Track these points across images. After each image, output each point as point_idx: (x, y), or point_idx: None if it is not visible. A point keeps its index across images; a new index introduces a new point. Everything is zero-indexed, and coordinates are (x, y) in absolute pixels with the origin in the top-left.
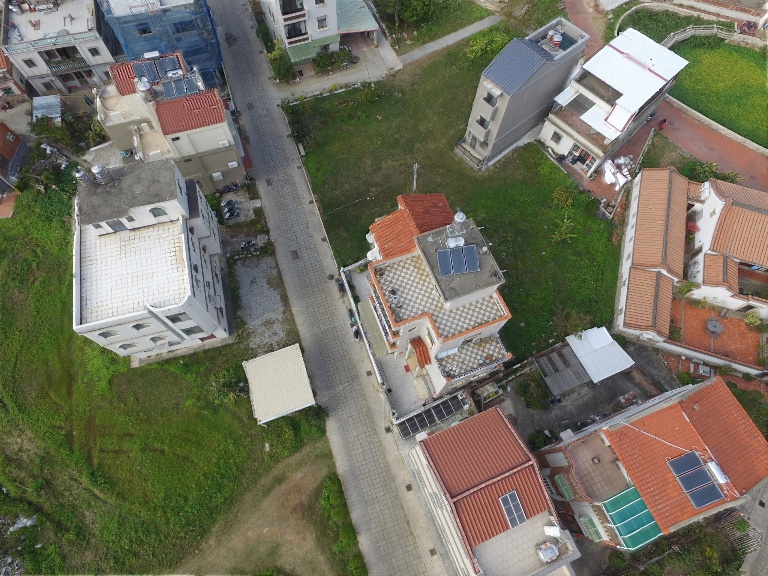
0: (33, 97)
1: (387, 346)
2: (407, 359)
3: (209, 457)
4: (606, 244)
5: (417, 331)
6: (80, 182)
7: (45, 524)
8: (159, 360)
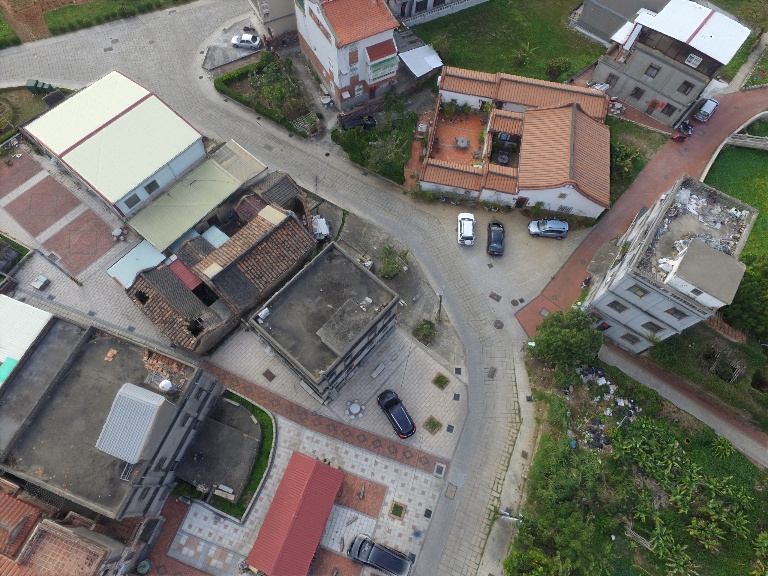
0: None
1: None
2: None
3: None
4: None
5: None
6: None
7: None
8: None
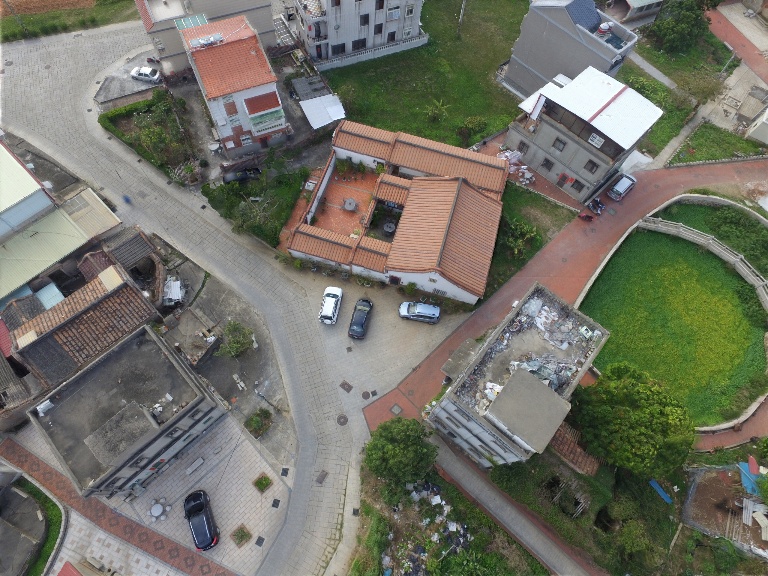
0: None
1: None
2: None
3: None
4: None
5: None
6: None
7: None
8: None
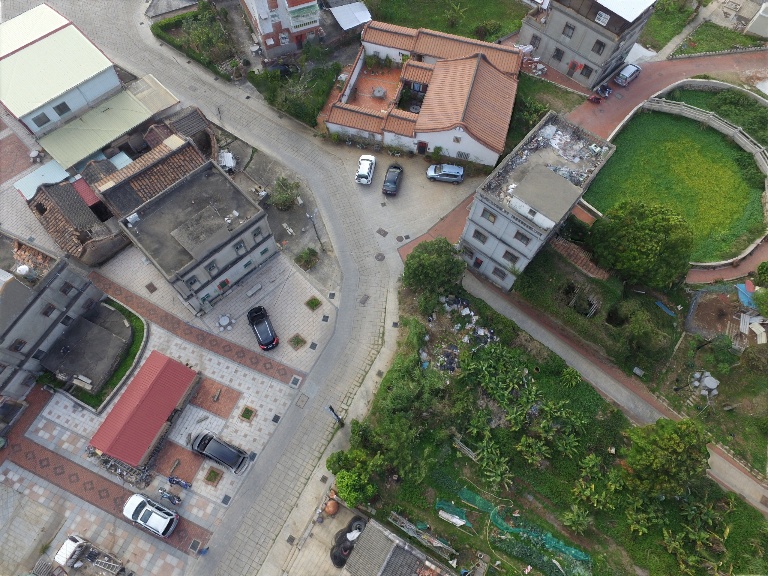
0: None
1: None
2: None
3: None
4: None
5: None
6: None
7: None
8: None
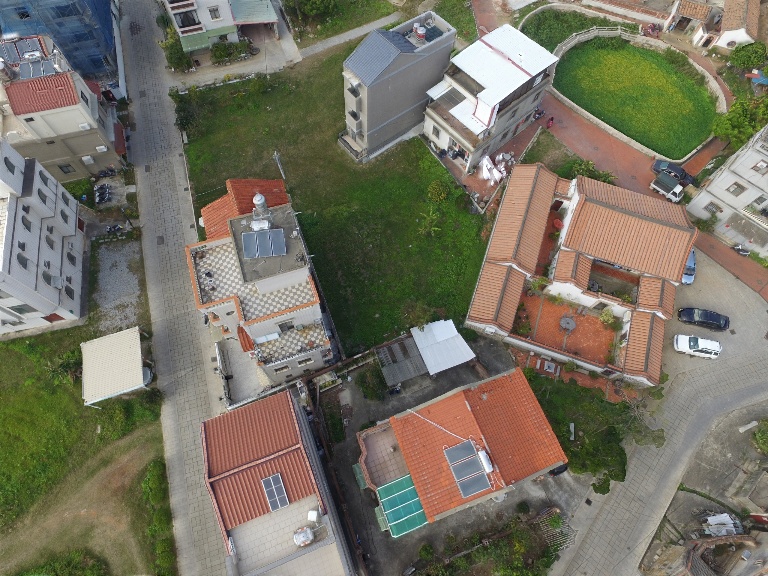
0: None
1: None
2: None
3: (40, 437)
4: (474, 239)
5: None
6: None
7: None
8: (5, 340)
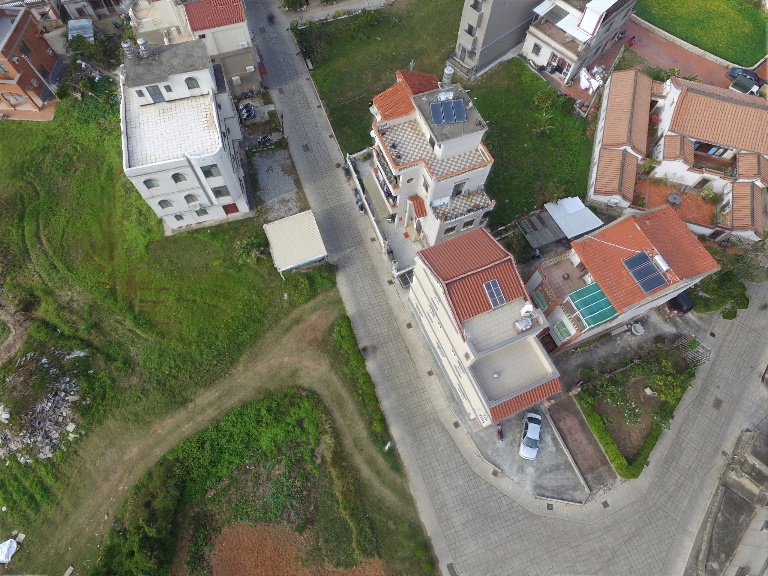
0: (68, 21)
1: (389, 208)
2: (406, 227)
3: (235, 305)
4: (581, 137)
5: (414, 185)
6: (127, 54)
7: (96, 355)
8: (189, 230)
